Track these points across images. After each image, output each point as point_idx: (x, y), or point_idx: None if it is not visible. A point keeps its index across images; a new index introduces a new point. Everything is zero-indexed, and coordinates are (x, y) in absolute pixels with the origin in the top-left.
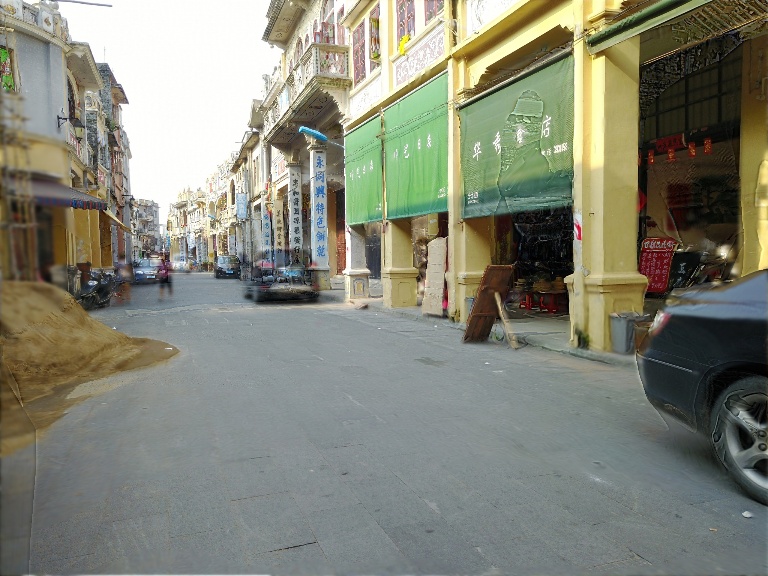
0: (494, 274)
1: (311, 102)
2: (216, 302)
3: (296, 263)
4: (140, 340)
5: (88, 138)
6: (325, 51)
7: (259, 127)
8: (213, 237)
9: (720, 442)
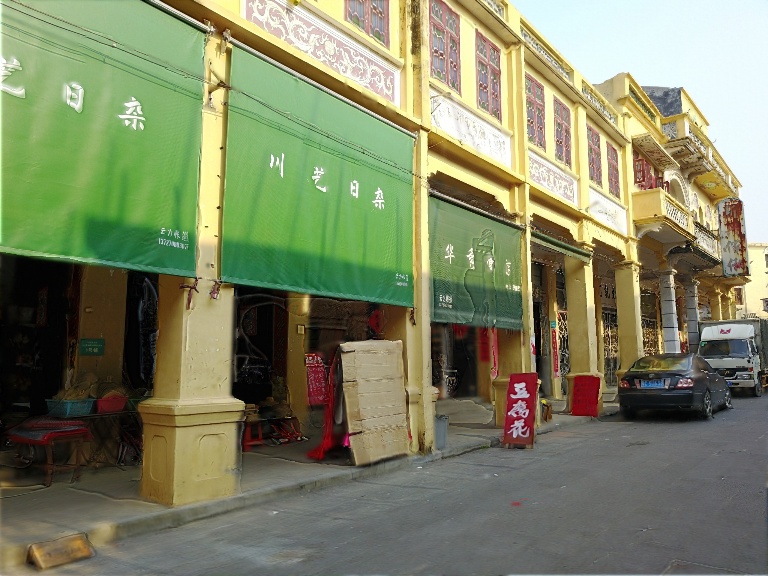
0: None
1: None
2: None
3: None
4: None
5: None
6: None
7: None
8: None
9: (708, 409)
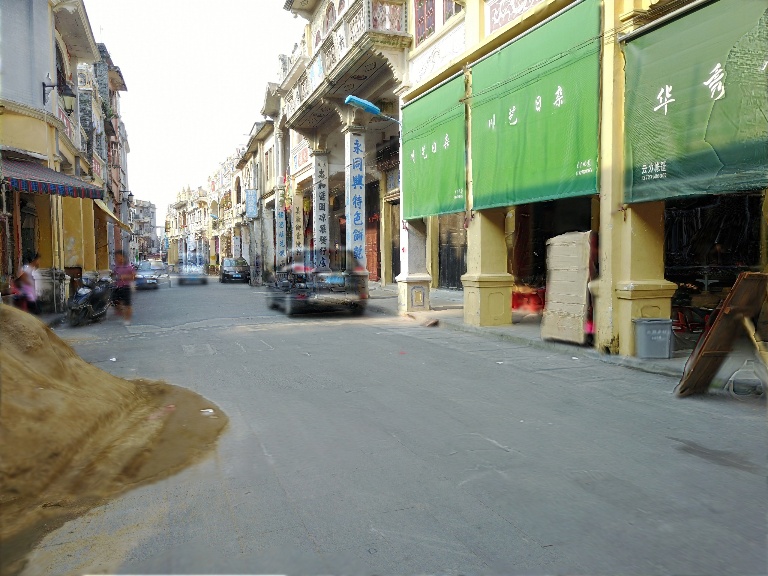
0: (749, 287)
1: (355, 70)
2: (237, 314)
3: (322, 267)
4: (156, 389)
5: (81, 122)
6: (379, 1)
7: (273, 115)
8: (215, 238)
9: None
